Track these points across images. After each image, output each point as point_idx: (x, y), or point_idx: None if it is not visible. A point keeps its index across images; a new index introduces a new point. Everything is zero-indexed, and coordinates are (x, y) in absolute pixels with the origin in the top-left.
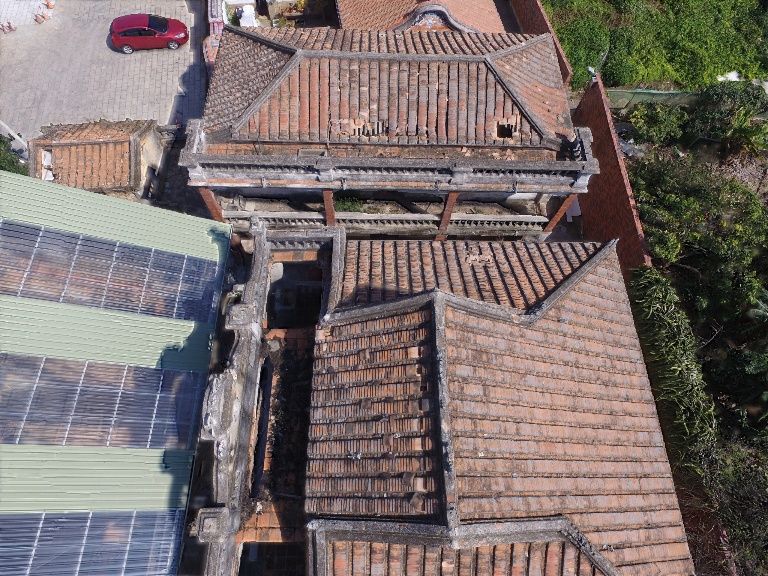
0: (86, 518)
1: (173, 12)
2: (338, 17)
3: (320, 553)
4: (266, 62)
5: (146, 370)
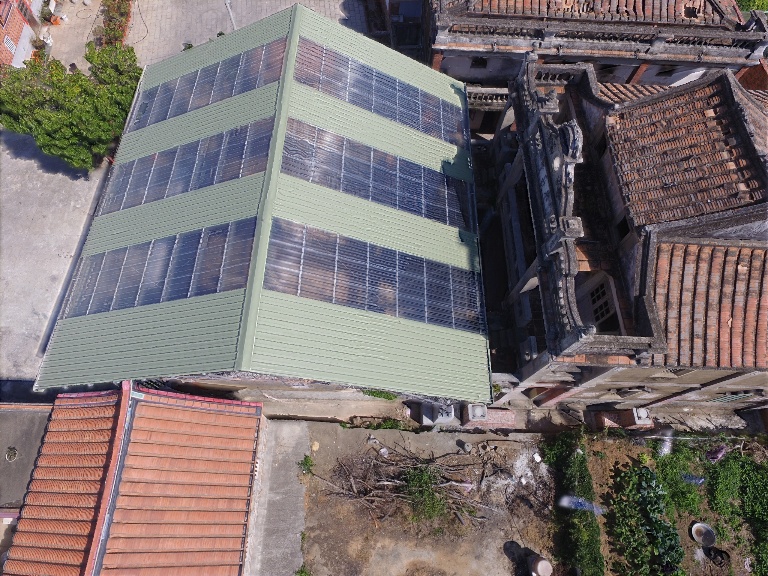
0: (422, 261)
1: None
2: None
3: (651, 251)
4: None
5: (434, 172)
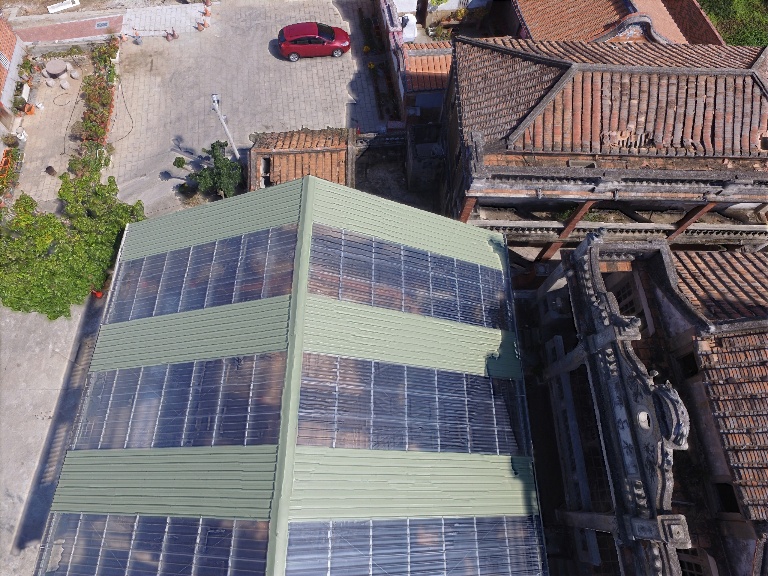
0: (472, 523)
1: (328, 20)
2: (524, 27)
3: None
4: (528, 75)
5: (478, 378)
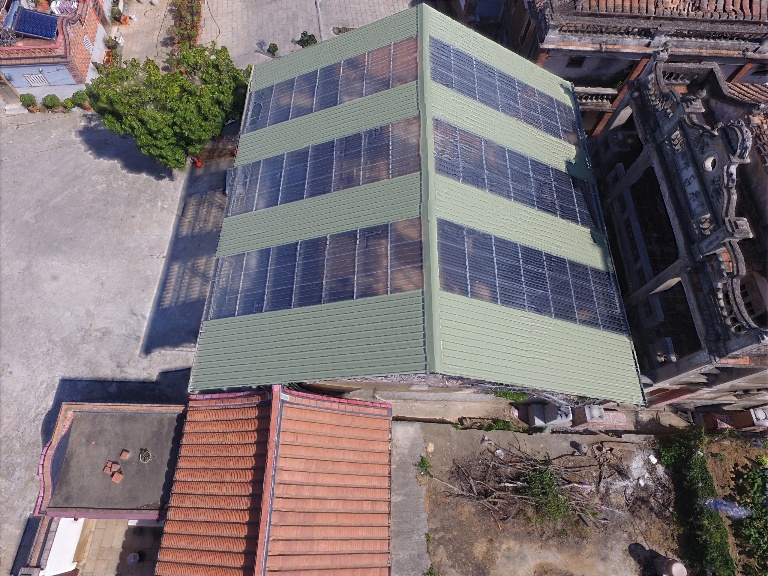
0: (565, 262)
1: None
2: None
3: None
4: None
5: (560, 173)
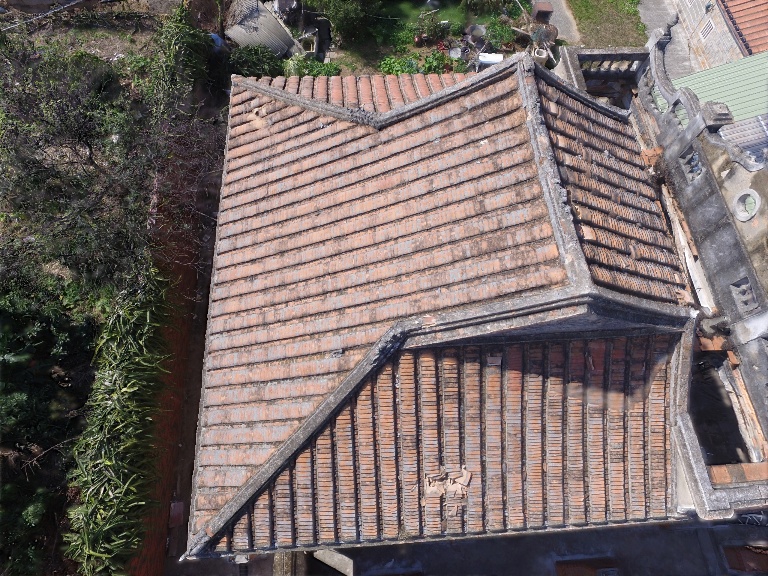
0: None
1: None
2: None
3: None
4: None
5: None
